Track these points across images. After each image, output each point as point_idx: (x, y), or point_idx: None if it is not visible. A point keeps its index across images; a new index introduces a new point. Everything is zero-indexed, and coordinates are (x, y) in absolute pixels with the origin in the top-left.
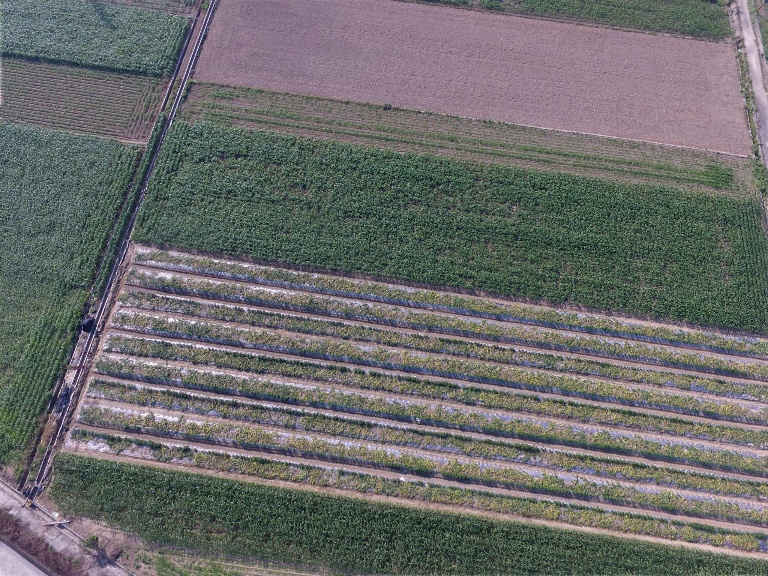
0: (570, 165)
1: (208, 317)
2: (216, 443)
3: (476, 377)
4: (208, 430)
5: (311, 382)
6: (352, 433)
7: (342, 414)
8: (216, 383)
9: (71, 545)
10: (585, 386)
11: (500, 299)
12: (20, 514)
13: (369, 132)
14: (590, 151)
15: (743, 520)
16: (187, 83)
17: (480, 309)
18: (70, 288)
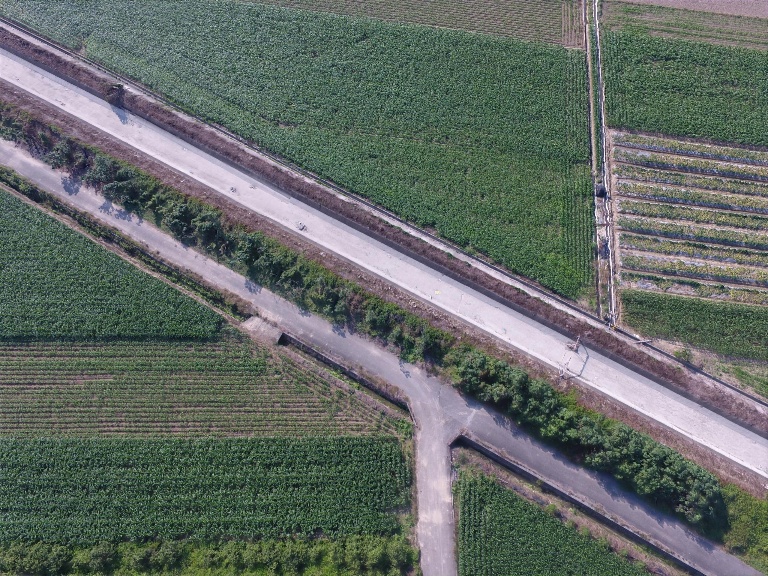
0: None
1: (693, 186)
2: (742, 283)
3: None
4: (734, 272)
5: None
6: None
7: None
8: (723, 237)
9: (663, 358)
10: None
11: None
12: (613, 334)
13: (767, 40)
14: None
15: None
16: (599, 0)
17: None
18: (572, 163)
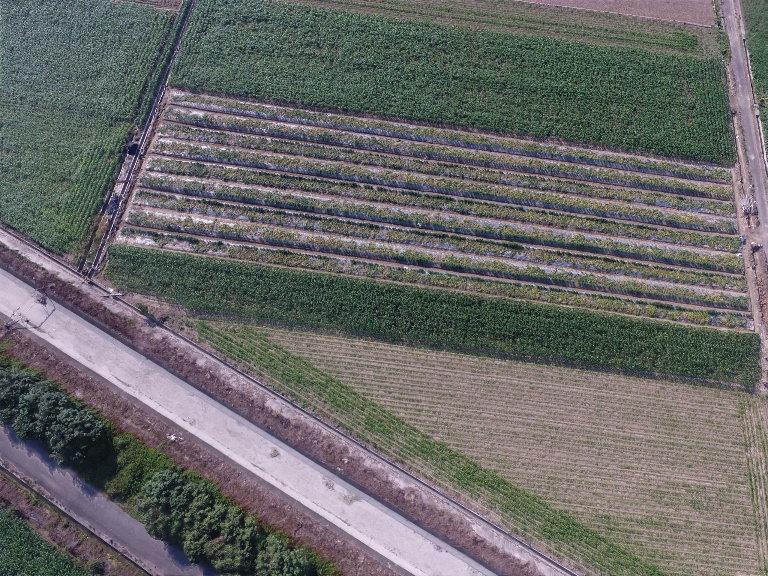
0: (553, 32)
1: (236, 145)
2: (246, 240)
3: (469, 193)
4: (239, 229)
5: (326, 196)
6: (362, 233)
7: (354, 220)
8: (244, 195)
9: (125, 311)
10: (564, 200)
11: (491, 135)
12: (81, 287)
13: (375, 4)
14: (571, 21)
15: (698, 302)
16: None
17: (473, 141)
18: (116, 121)
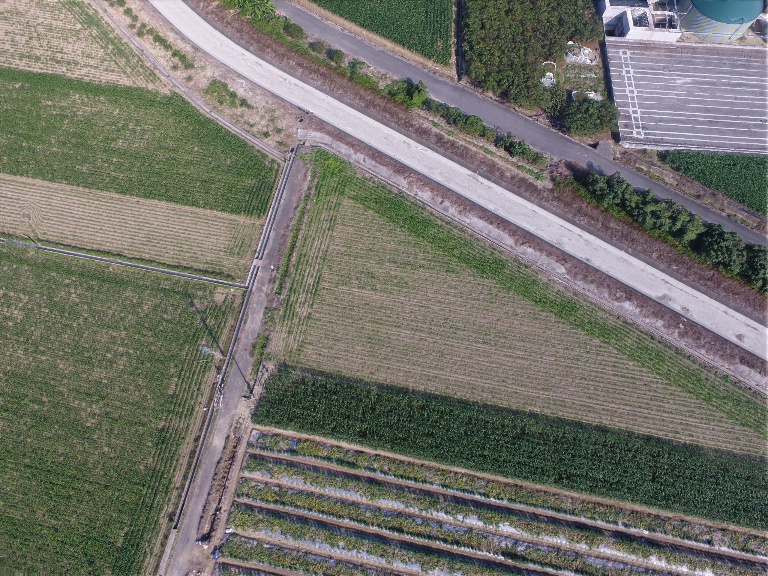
0: None
1: None
2: None
3: None
4: None
5: None
6: None
7: None
8: None
9: None
10: None
11: None
12: None
13: None
14: None
15: (303, 468)
16: None
17: None
18: None
